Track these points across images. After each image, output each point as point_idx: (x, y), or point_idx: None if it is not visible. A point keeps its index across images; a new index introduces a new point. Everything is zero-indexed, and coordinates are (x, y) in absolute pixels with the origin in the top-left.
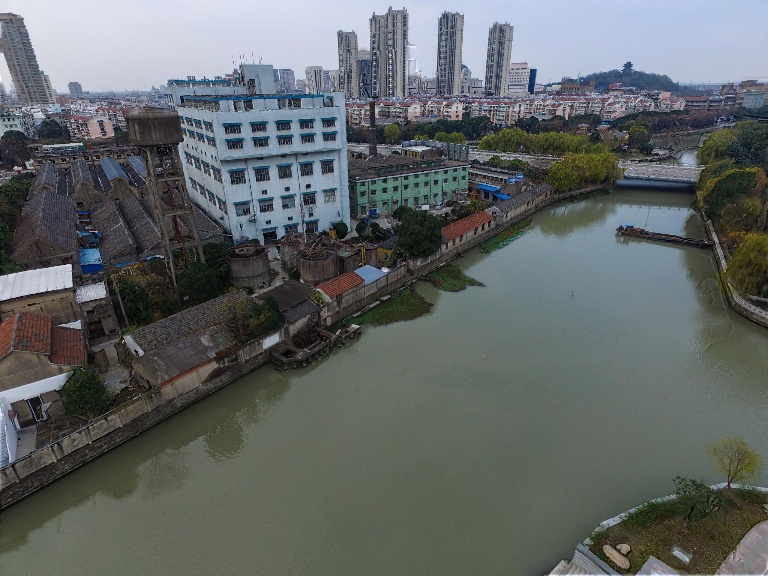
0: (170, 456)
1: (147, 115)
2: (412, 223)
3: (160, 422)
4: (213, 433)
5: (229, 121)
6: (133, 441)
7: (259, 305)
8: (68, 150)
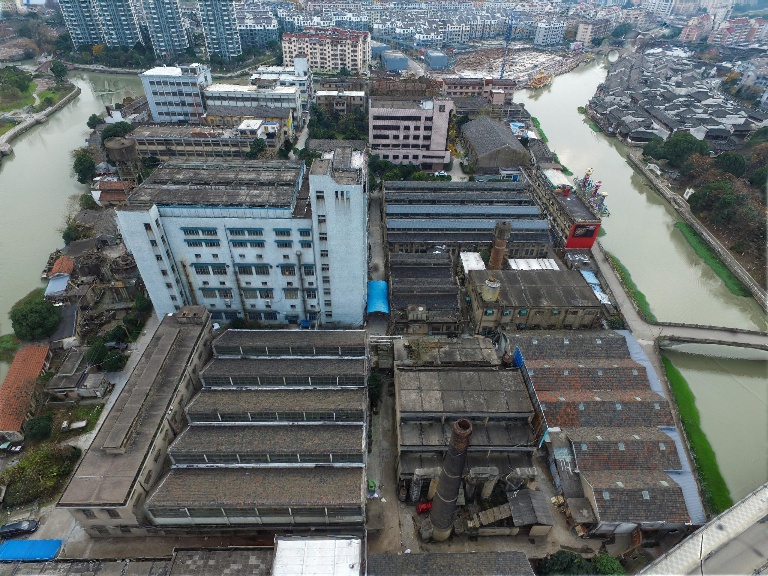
0: None
1: None
2: (34, 302)
3: None
4: None
5: None
6: None
7: (69, 230)
8: None
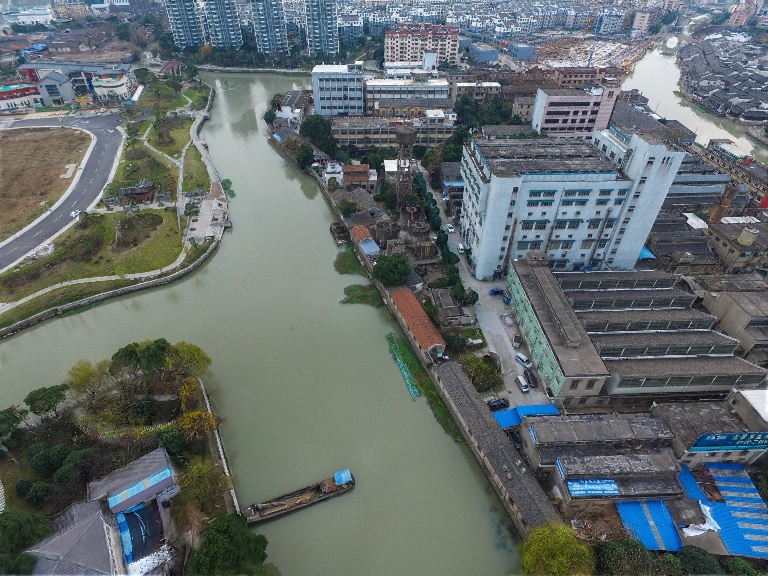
0: None
1: None
2: None
3: None
4: None
5: None
6: None
7: None
8: (727, 155)
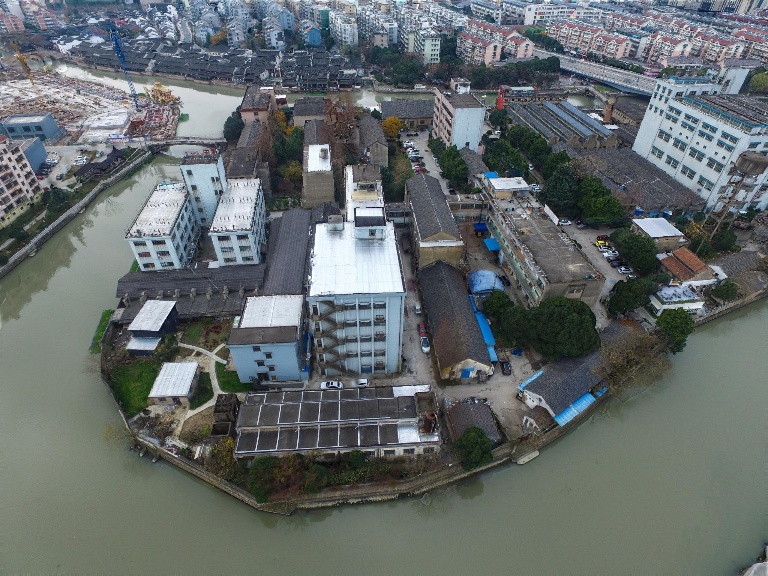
0: (728, 323)
1: (762, 161)
2: None
3: (737, 309)
4: (740, 319)
5: (755, 141)
6: (729, 313)
7: None
8: (524, 93)
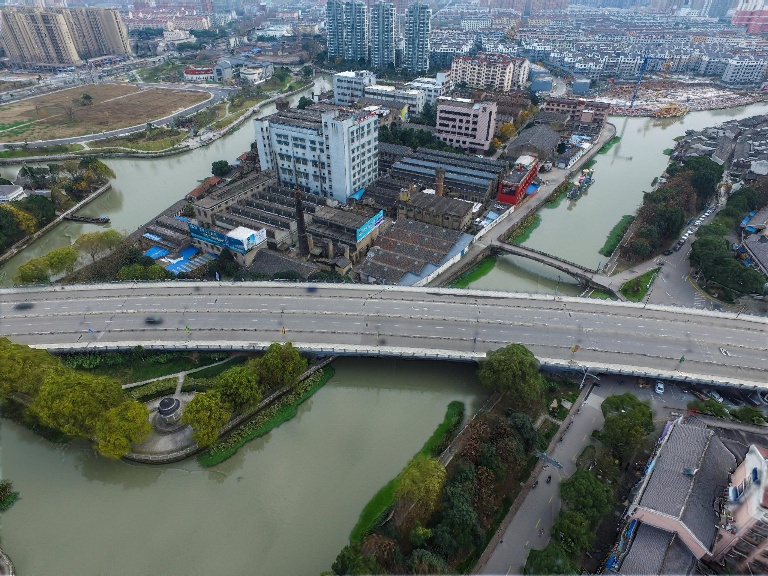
0: None
1: None
2: None
3: None
4: None
5: None
6: None
7: (254, 143)
8: None
